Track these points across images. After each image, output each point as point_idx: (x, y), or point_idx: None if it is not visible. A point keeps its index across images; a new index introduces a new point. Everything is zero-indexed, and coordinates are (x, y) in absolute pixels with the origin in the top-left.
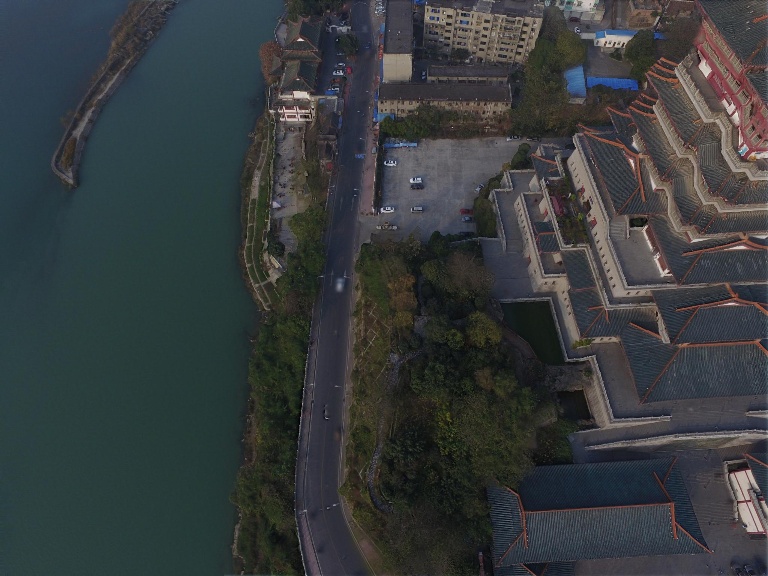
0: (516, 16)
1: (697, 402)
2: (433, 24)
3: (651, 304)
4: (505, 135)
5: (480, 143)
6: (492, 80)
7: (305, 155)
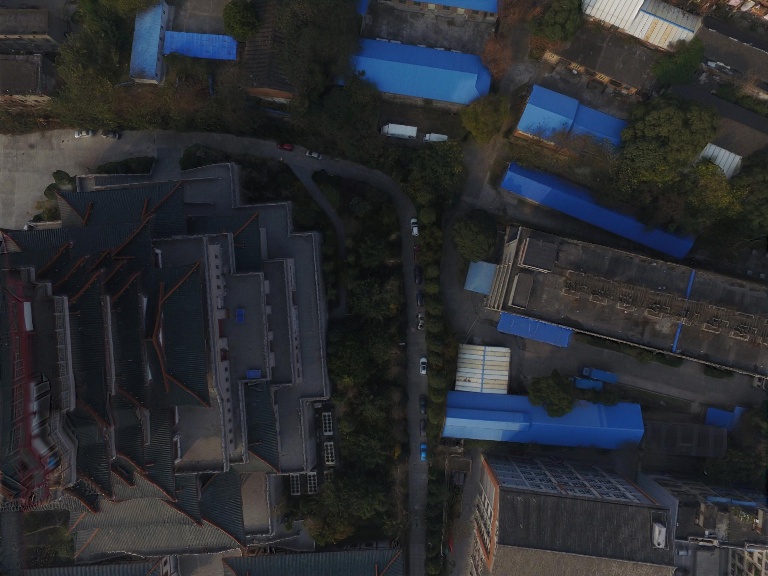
0: None
1: None
2: None
3: None
4: (74, 126)
5: (41, 141)
6: (29, 37)
7: None
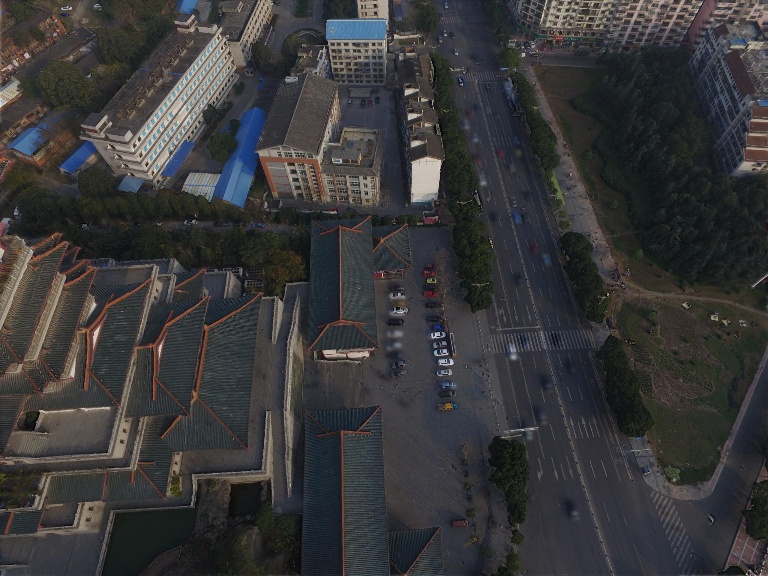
0: None
1: (258, 382)
2: None
3: (142, 418)
4: None
5: None
6: None
7: None
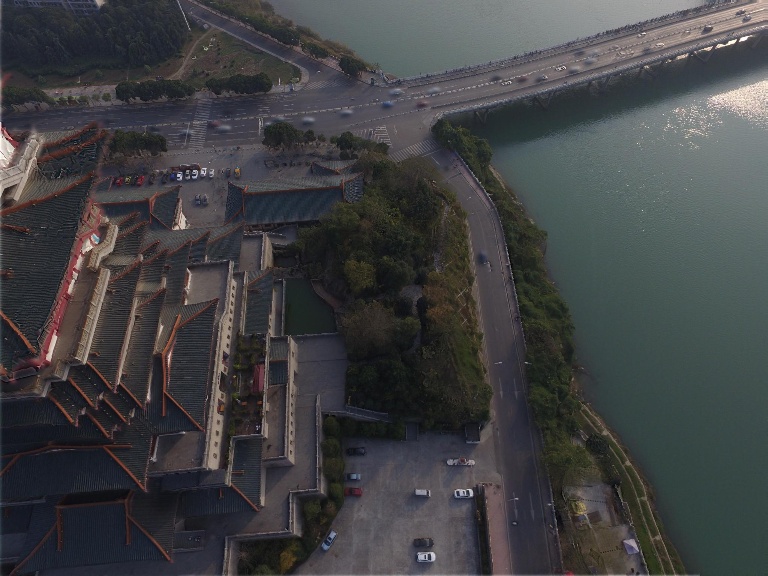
0: None
1: None
2: None
3: None
4: None
5: None
6: None
7: None
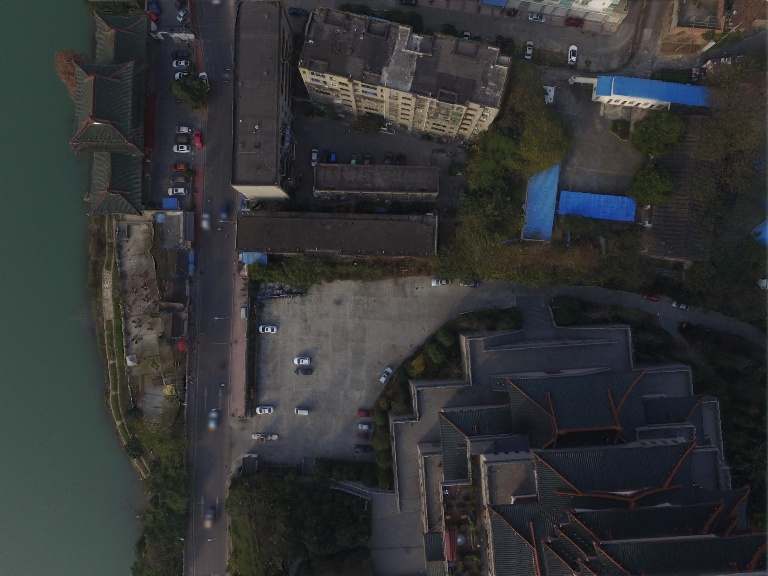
0: (454, 102)
1: None
2: (319, 86)
3: None
4: (430, 274)
5: (394, 288)
6: (414, 193)
7: (157, 286)
